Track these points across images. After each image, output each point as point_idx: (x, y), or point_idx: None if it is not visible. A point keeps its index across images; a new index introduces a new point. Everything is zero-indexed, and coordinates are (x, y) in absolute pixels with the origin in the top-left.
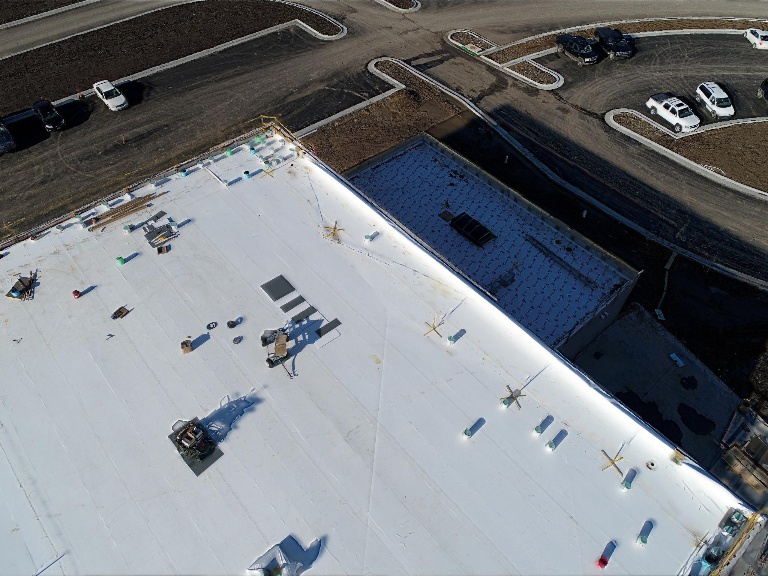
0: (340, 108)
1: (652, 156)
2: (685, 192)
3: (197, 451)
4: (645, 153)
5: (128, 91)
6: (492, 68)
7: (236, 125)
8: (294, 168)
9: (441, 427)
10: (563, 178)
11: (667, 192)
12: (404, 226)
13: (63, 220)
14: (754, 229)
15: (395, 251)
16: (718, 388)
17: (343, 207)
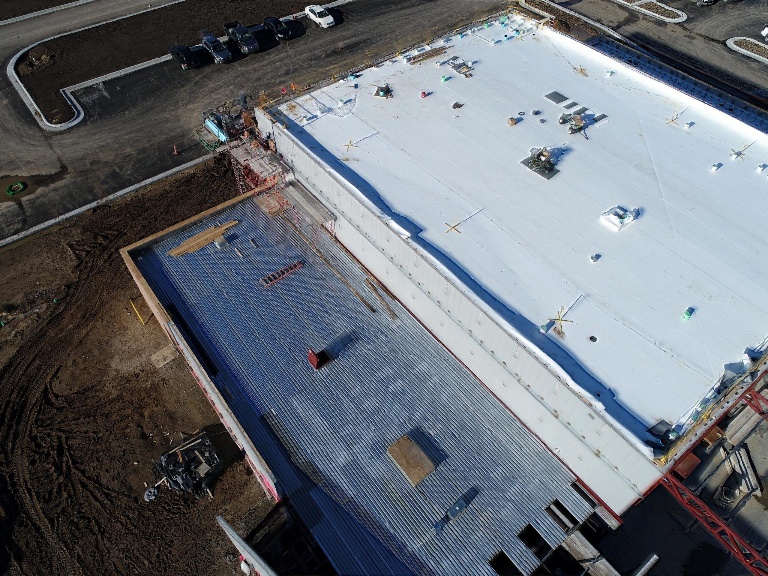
0: None
1: None
2: None
3: (545, 167)
4: (764, 68)
5: None
6: (623, 6)
7: None
8: (536, 36)
9: (695, 165)
10: None
11: None
12: None
13: (391, 57)
14: None
15: (630, 82)
16: None
17: (582, 58)
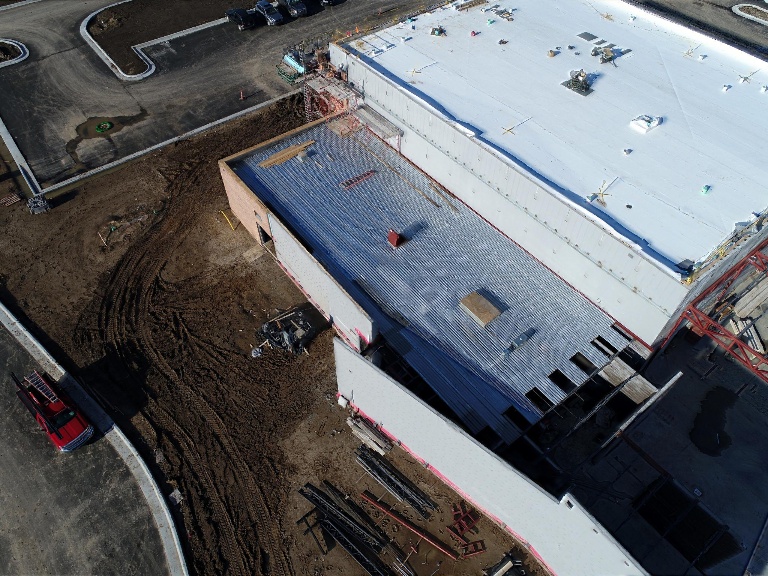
0: None
1: None
2: None
3: (582, 86)
4: (767, 30)
5: None
6: None
7: None
8: None
9: (708, 87)
10: None
11: None
12: None
13: (442, 5)
14: None
15: (650, 25)
16: None
17: (608, 7)
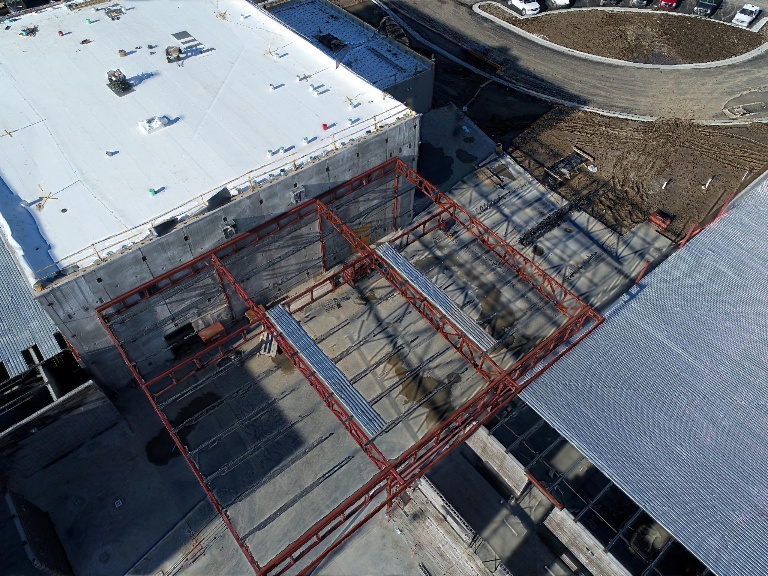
0: None
1: (499, 29)
2: (514, 49)
3: (120, 86)
4: (494, 27)
5: None
6: None
7: None
8: None
9: (259, 86)
10: (427, 40)
11: (501, 49)
12: None
13: (55, 5)
14: (555, 70)
15: (258, 23)
16: (487, 142)
17: (233, 5)
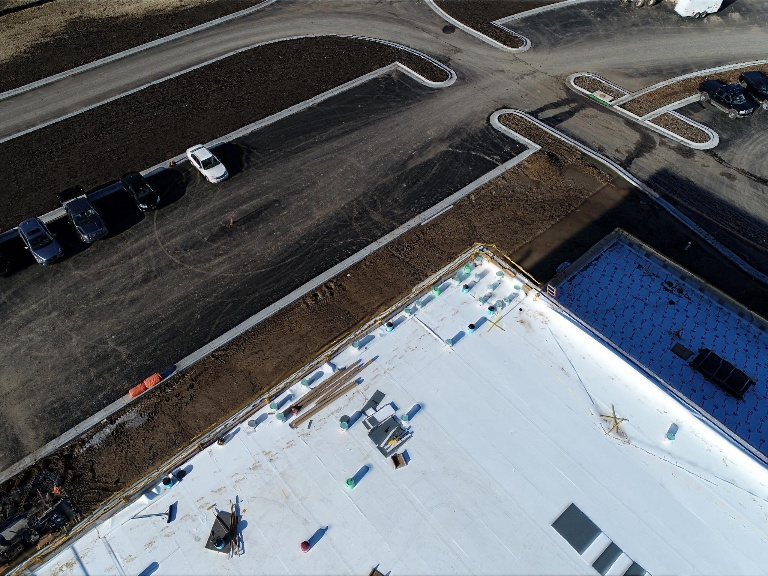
0: (472, 176)
1: None
2: None
3: None
4: None
5: (224, 156)
6: (631, 122)
7: (357, 200)
8: (525, 315)
9: None
10: (758, 269)
11: None
12: (714, 418)
13: (254, 411)
14: None
15: (711, 458)
16: None
17: (613, 380)
